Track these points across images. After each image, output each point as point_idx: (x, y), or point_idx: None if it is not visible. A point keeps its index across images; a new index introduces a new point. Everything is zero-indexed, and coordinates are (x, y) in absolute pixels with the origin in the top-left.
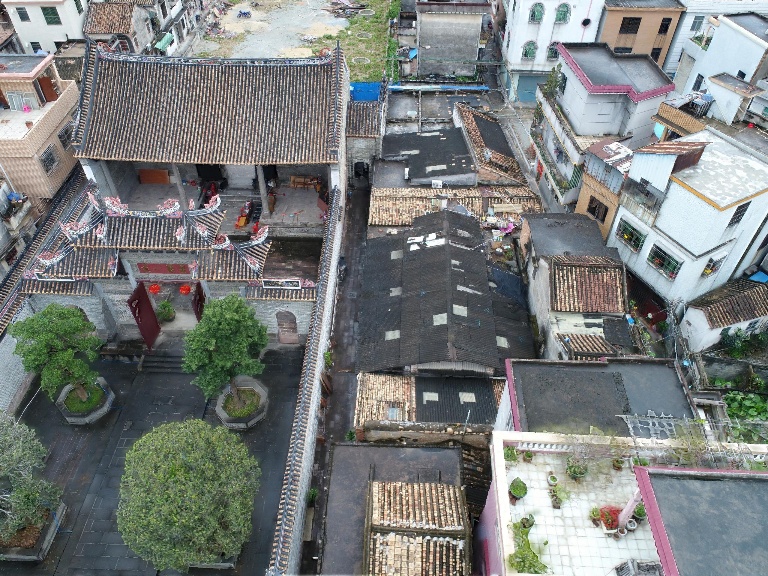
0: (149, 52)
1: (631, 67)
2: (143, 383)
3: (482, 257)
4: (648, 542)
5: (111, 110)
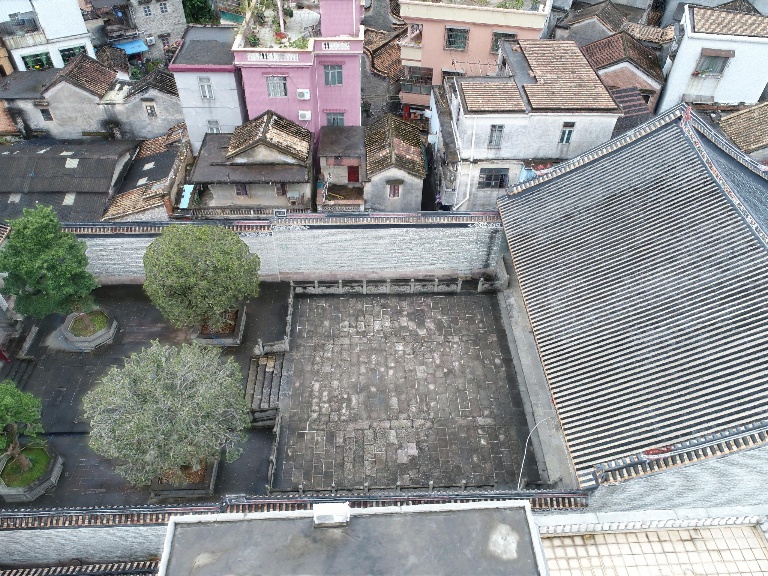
0: None
1: None
2: None
3: (3, 146)
4: None
5: None
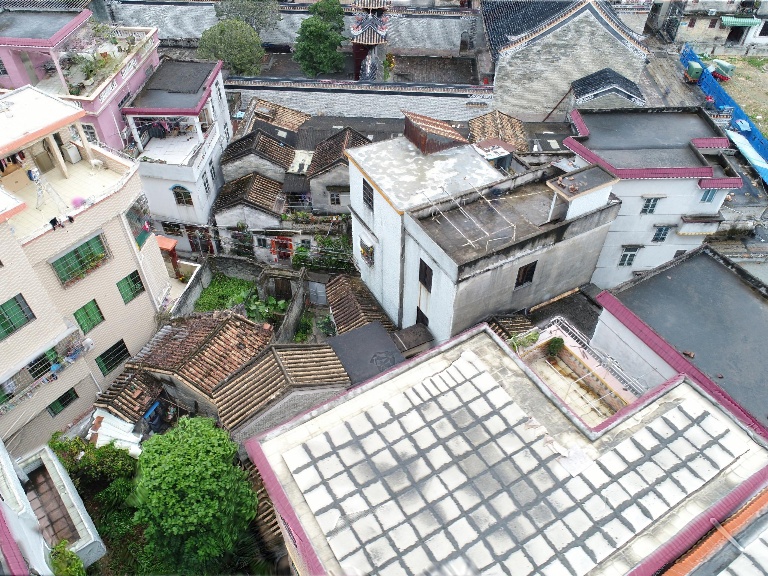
0: (708, 16)
1: (669, 156)
2: (339, 78)
3: None
4: None
5: None
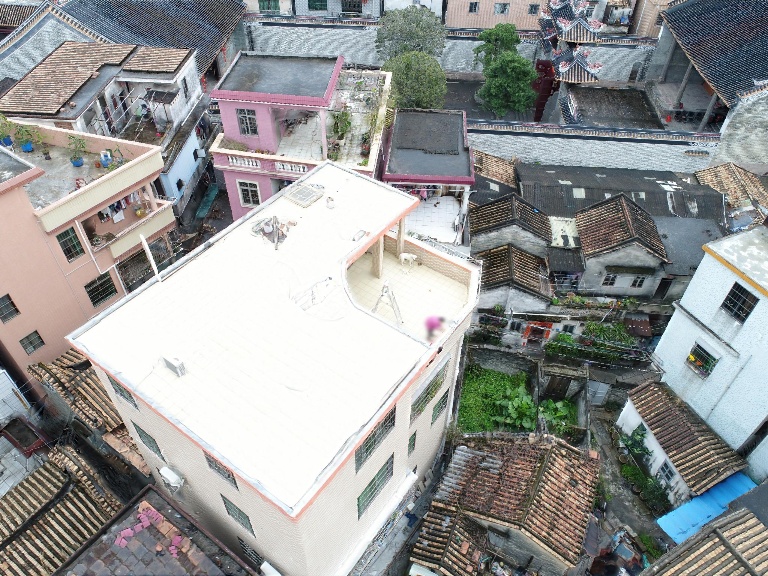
0: None
1: None
2: None
3: None
4: (327, 121)
5: (712, 3)
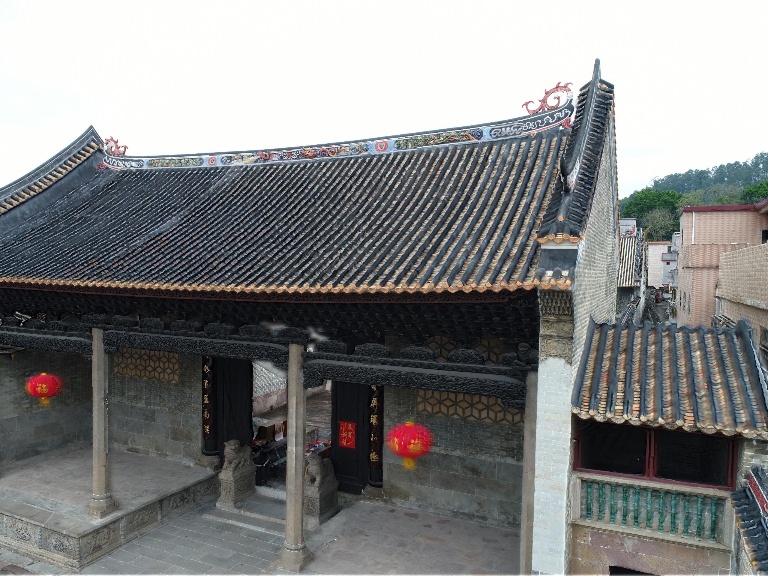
0: None
1: None
2: None
3: None
4: None
5: None
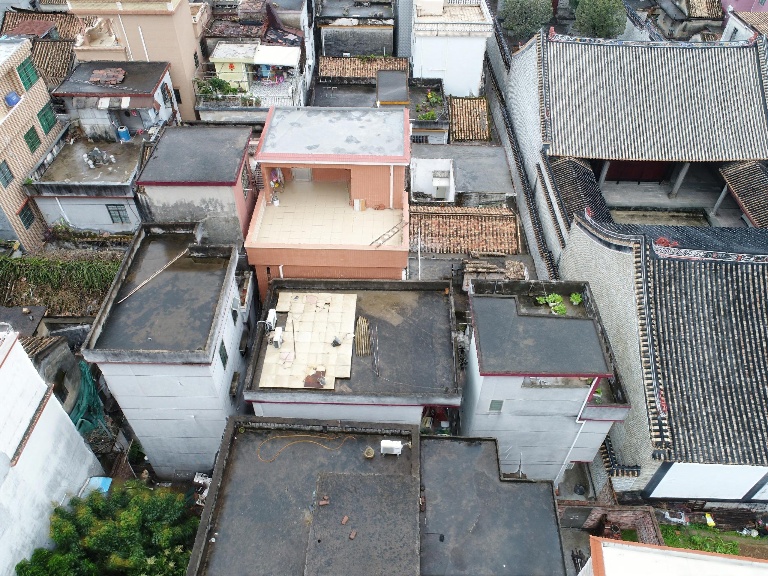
0: None
1: None
2: None
3: None
4: None
5: None
